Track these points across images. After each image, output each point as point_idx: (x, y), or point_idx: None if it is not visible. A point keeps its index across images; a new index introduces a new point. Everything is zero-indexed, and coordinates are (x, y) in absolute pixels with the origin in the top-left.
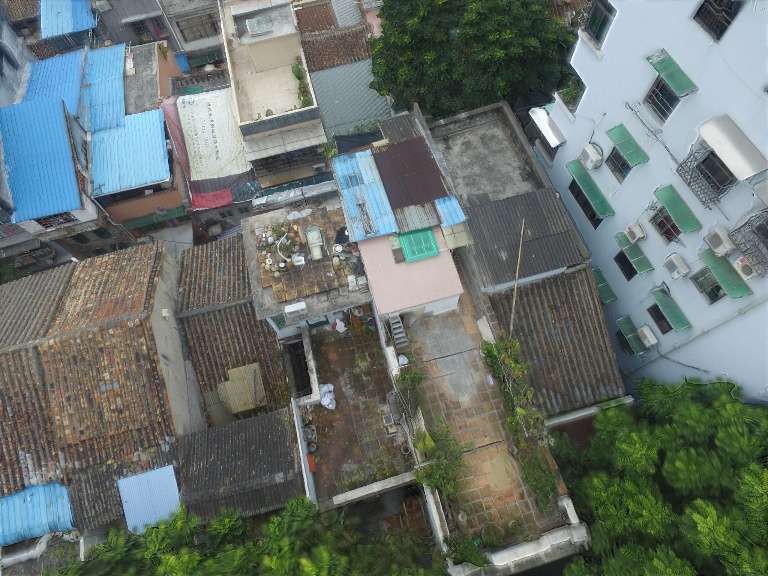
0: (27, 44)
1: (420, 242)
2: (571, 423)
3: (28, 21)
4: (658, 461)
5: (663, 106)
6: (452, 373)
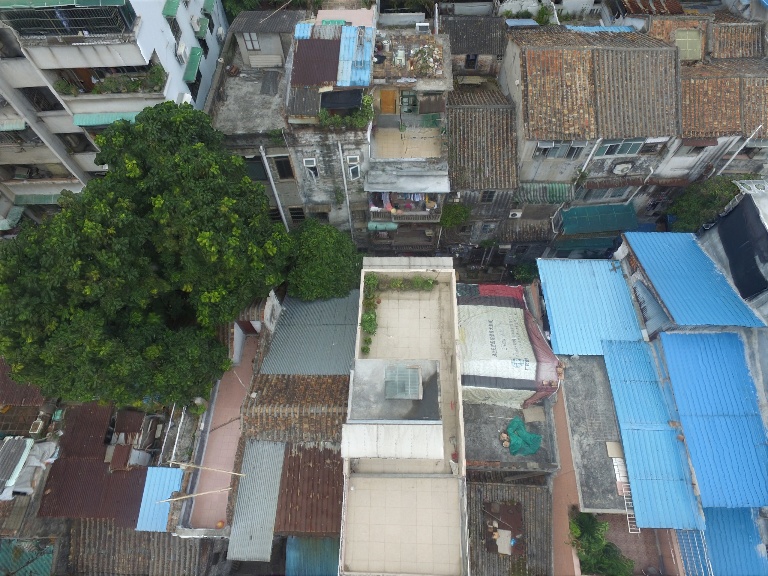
0: None
1: None
2: None
3: None
4: None
5: None
6: None
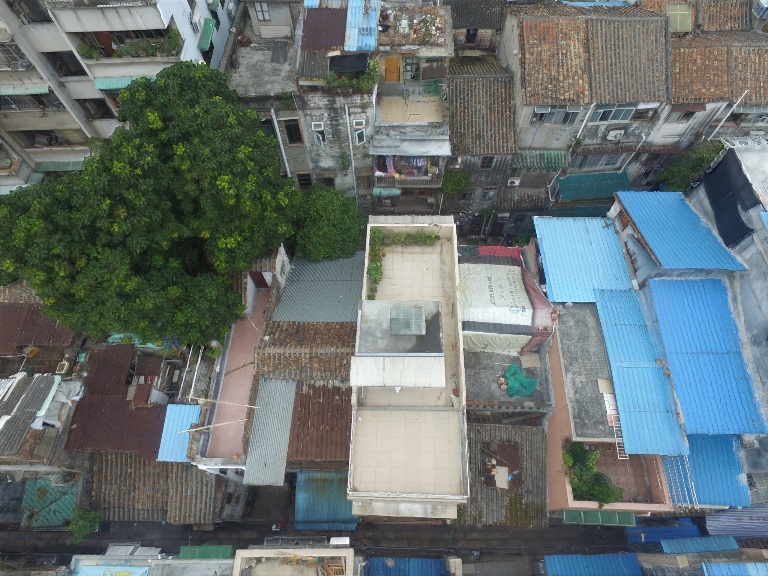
0: None
1: None
2: None
3: None
4: None
5: None
6: None
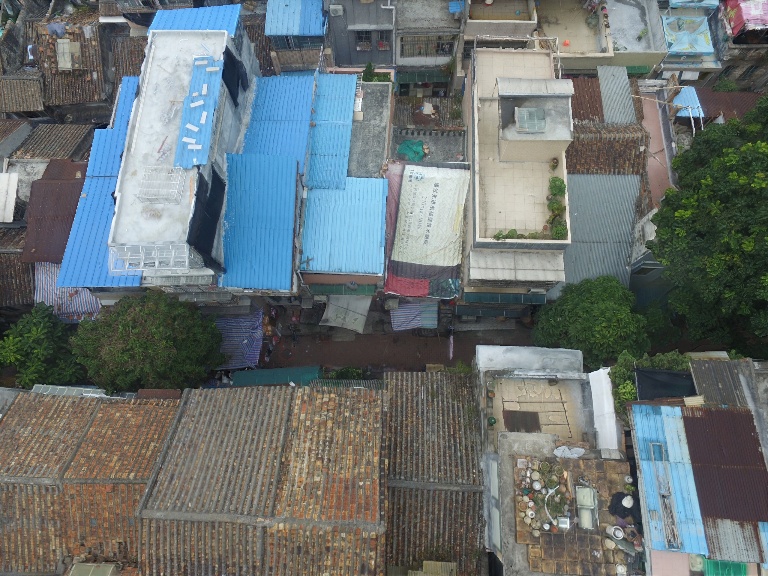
0: None
1: (724, 567)
2: None
3: None
4: None
5: None
6: None
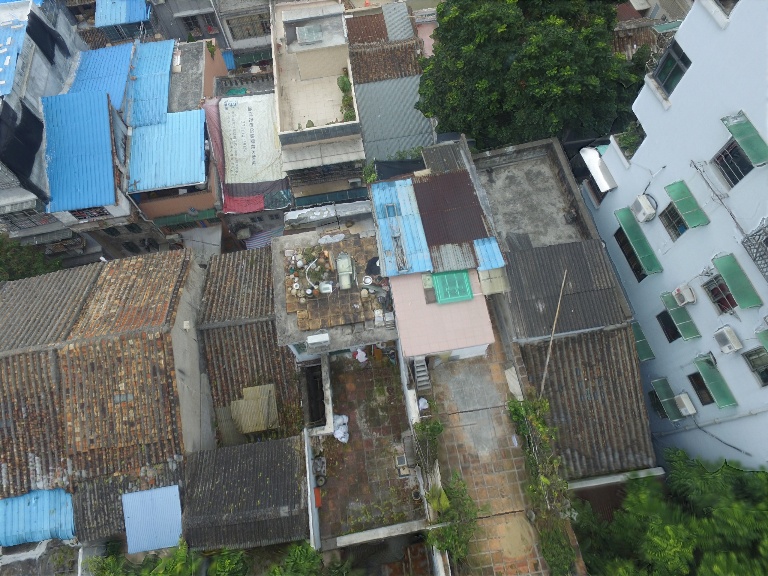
0: (80, 31)
1: (454, 283)
2: (594, 490)
3: (83, 7)
4: (693, 562)
5: (733, 170)
6: (474, 424)
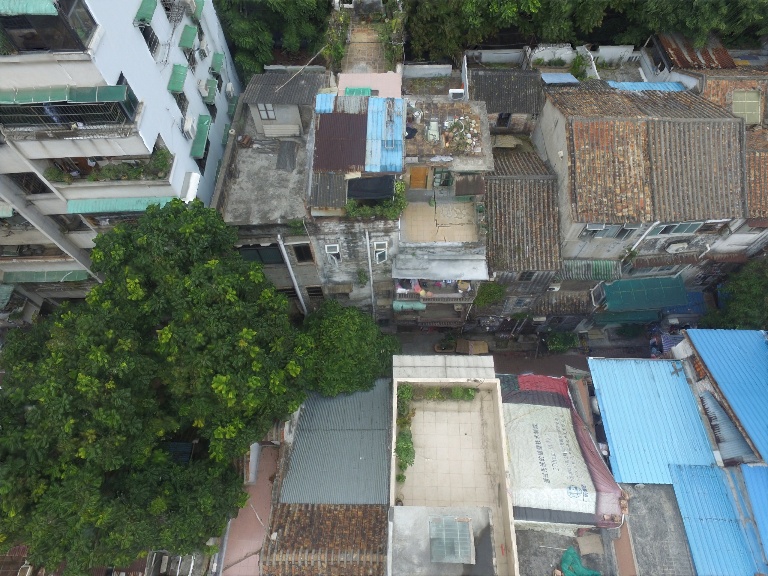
0: None
1: None
2: None
3: None
4: None
5: (153, 39)
6: None
